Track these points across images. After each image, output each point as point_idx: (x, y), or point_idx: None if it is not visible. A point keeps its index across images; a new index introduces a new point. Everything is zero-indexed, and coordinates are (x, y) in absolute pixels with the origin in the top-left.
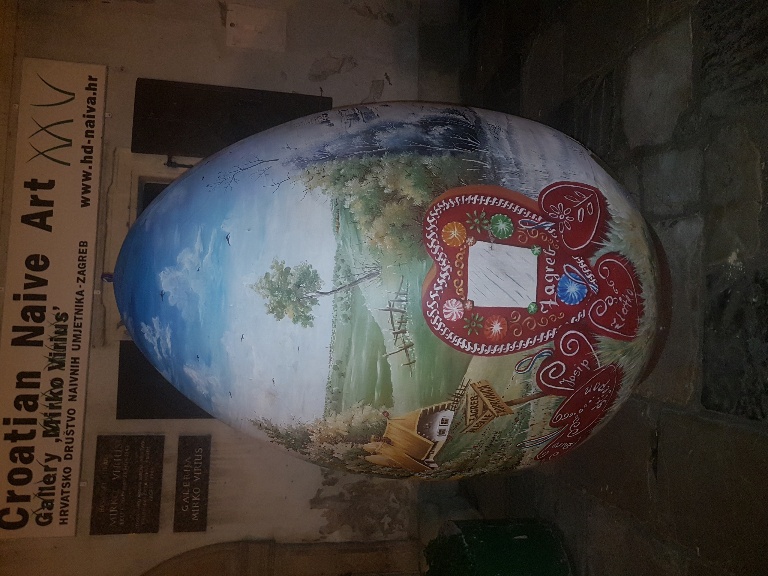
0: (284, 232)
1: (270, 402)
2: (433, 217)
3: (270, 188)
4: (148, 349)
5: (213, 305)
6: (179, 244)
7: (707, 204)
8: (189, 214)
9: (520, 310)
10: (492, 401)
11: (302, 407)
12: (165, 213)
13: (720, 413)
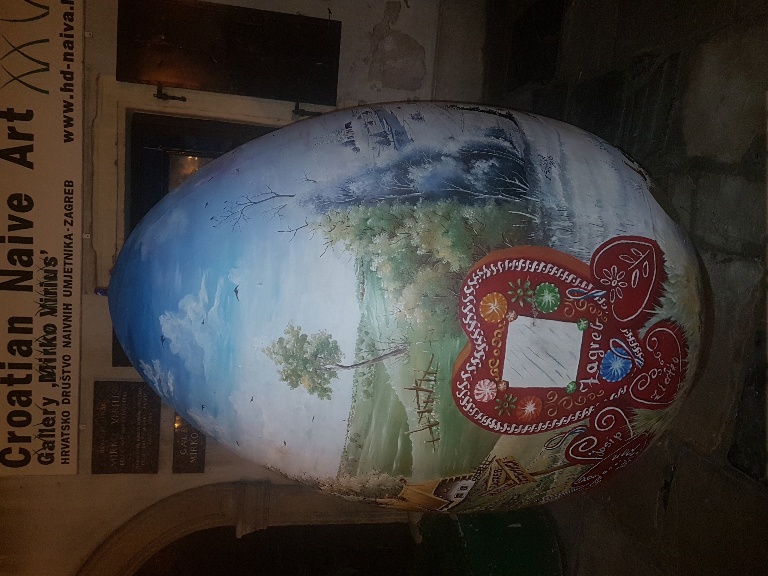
0: (301, 293)
1: (280, 458)
2: (471, 286)
3: (285, 235)
4: (147, 382)
5: (220, 363)
6: (180, 288)
7: None
8: (191, 251)
9: (558, 390)
10: (516, 473)
11: (314, 467)
12: (163, 243)
13: (747, 476)
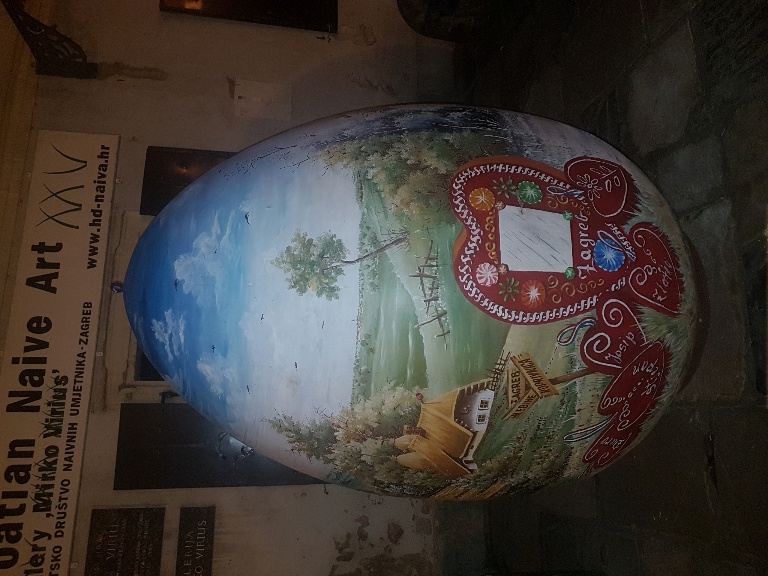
0: (305, 205)
1: (292, 392)
2: (459, 184)
3: (290, 168)
4: (158, 351)
5: (231, 286)
6: (195, 230)
7: (732, 185)
8: (206, 203)
9: (557, 275)
10: (535, 378)
11: (327, 395)
12: (180, 206)
13: None
